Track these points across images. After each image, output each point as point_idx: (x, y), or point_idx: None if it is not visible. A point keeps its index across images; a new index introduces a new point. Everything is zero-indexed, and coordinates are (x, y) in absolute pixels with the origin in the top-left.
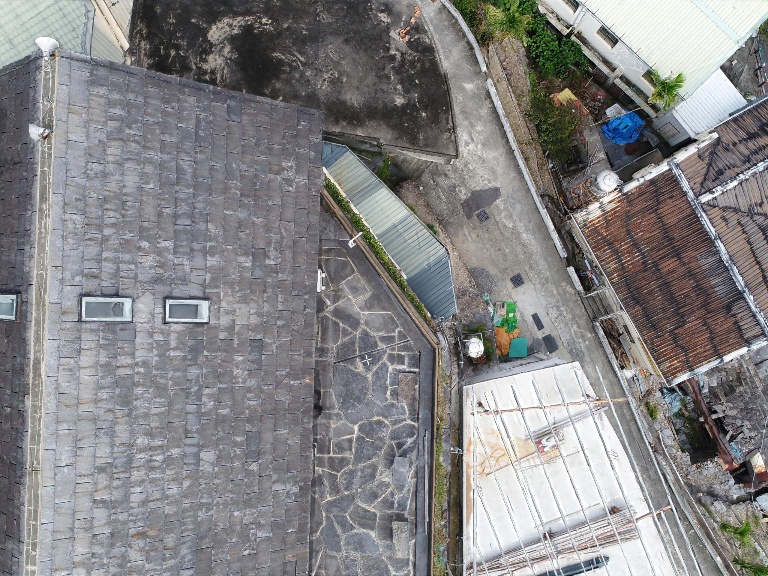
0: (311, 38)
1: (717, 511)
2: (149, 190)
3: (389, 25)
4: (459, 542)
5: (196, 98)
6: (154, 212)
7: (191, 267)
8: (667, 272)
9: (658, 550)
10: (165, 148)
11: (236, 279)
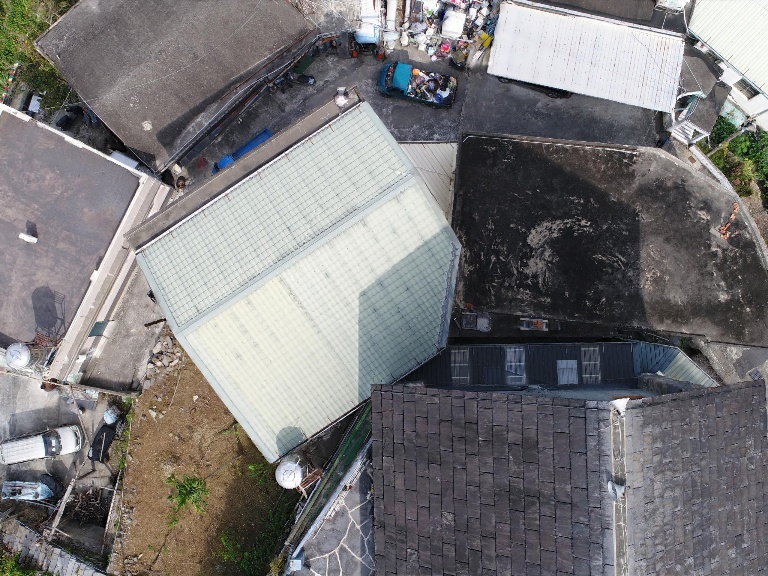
0: (631, 238)
1: None
2: (678, 512)
3: (709, 222)
4: None
5: (698, 406)
6: (682, 533)
7: (703, 575)
8: None
9: None
10: (684, 466)
11: (728, 573)
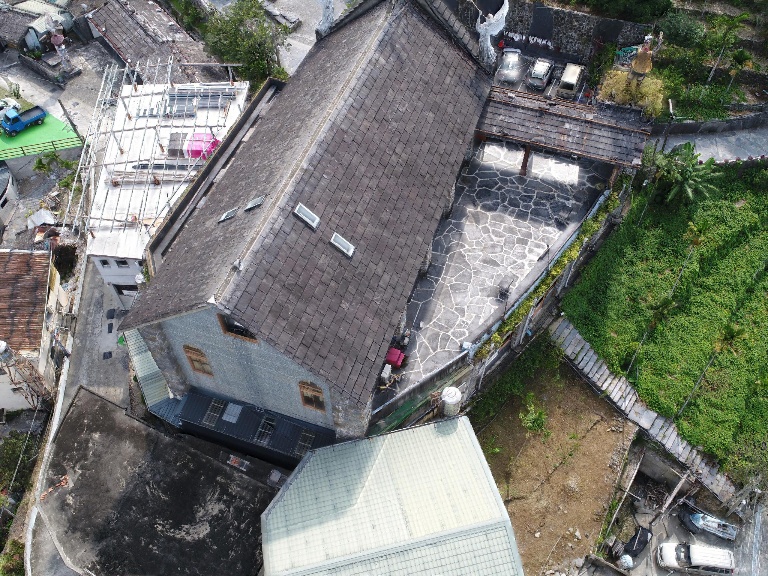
0: (133, 502)
1: None
2: None
3: (70, 493)
4: None
5: None
6: None
7: None
8: (6, 303)
9: None
10: None
11: None
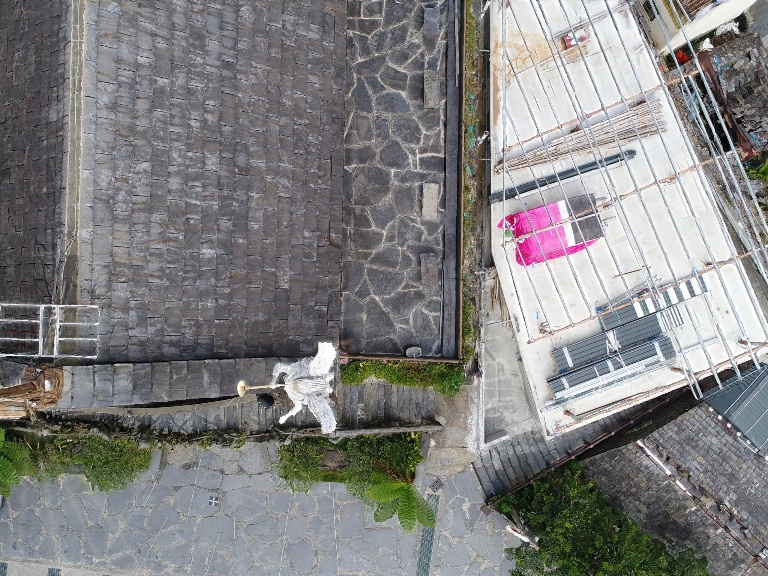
0: None
1: (737, 202)
2: None
3: None
4: (486, 153)
5: None
6: None
7: None
8: None
9: (684, 144)
10: None
11: None
